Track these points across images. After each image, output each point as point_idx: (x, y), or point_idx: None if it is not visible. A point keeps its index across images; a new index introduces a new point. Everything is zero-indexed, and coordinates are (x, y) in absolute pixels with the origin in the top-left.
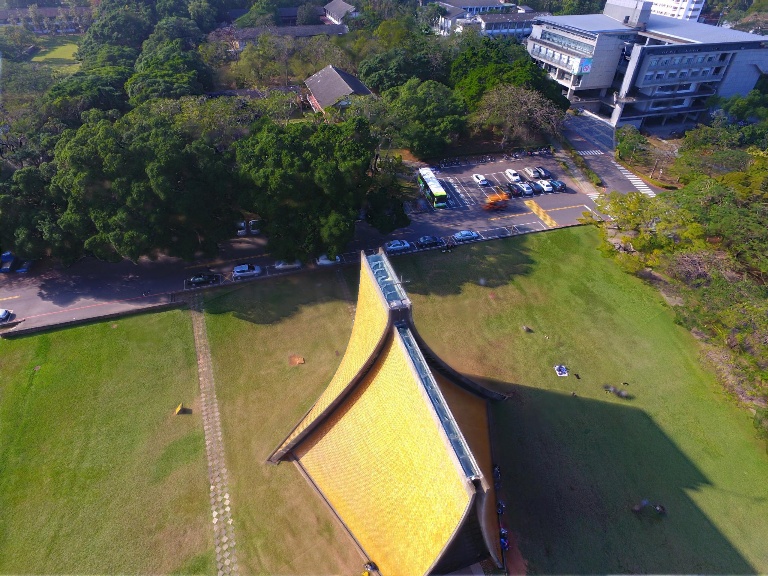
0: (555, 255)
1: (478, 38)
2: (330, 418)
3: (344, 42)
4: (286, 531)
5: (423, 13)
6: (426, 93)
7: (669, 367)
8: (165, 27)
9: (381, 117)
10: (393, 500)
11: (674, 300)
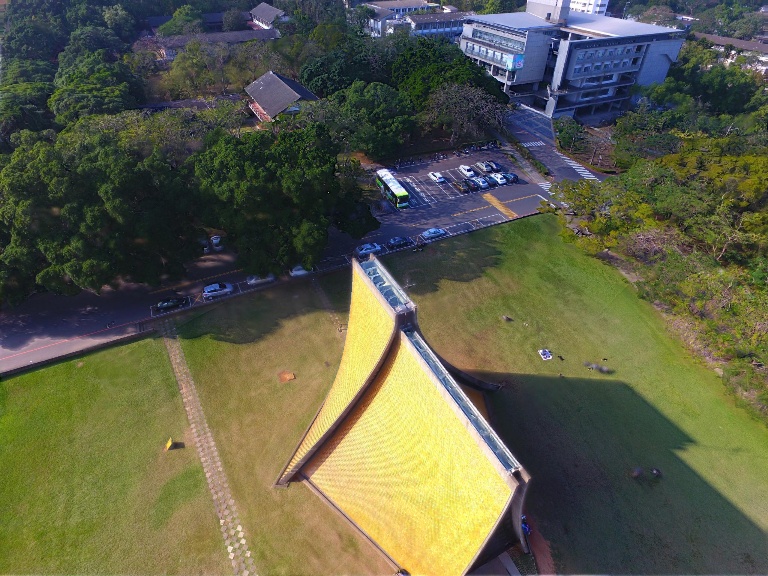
0: (520, 244)
1: (413, 38)
2: (338, 431)
3: (280, 47)
4: (309, 554)
5: (352, 15)
6: (373, 95)
7: (639, 339)
8: (82, 37)
9: (336, 121)
10: (420, 504)
11: (632, 276)
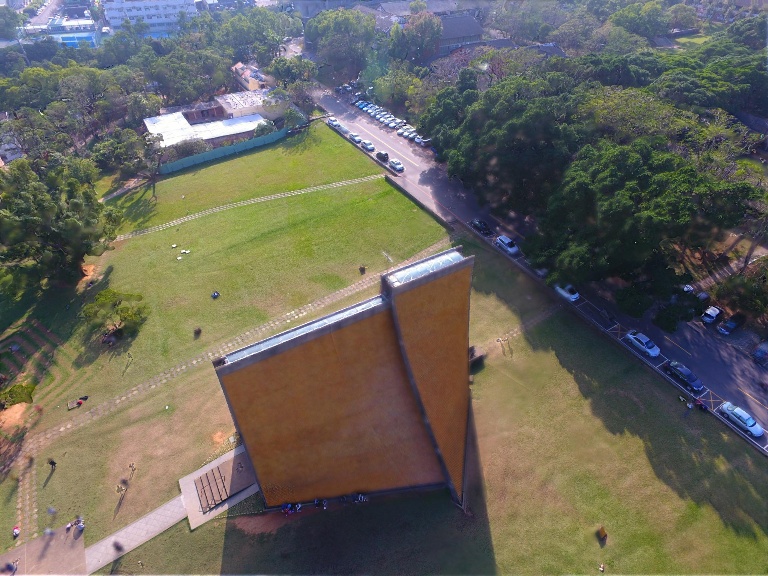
0: None
1: None
2: None
3: None
4: None
5: None
6: None
7: None
8: None
9: None
10: None
11: None
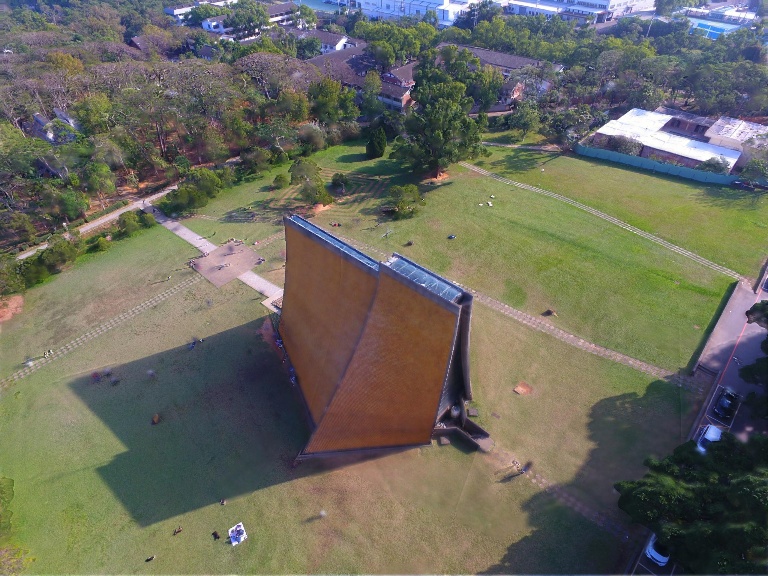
0: None
1: None
2: None
3: None
4: None
5: None
6: None
7: None
8: None
9: None
10: None
11: None
